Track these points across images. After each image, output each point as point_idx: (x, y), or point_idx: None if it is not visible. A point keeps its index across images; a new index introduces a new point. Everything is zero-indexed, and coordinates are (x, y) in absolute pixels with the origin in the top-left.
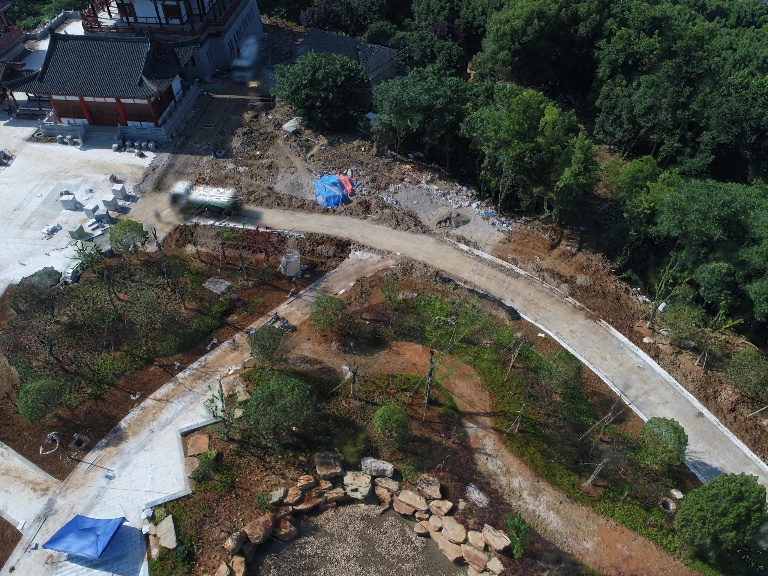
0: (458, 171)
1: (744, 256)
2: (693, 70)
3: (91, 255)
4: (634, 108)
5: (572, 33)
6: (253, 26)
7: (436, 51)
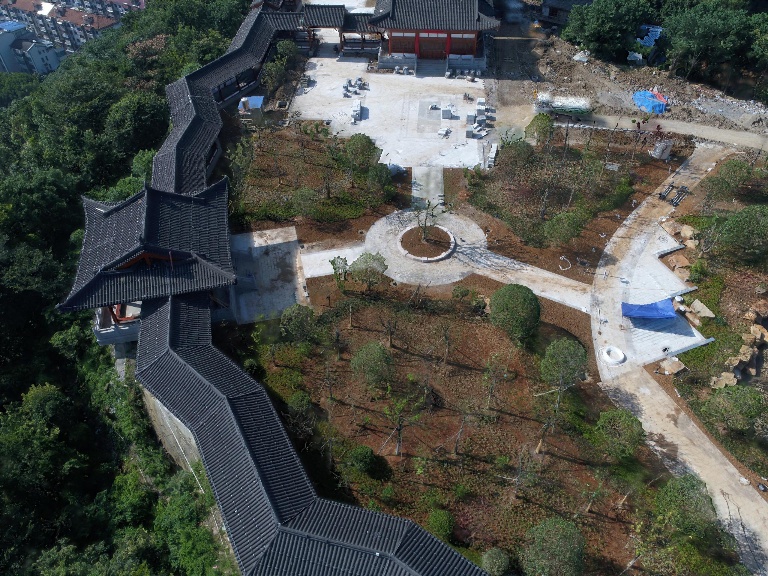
0: (727, 92)
1: None
2: None
3: (512, 142)
4: None
5: None
6: None
7: (662, 0)
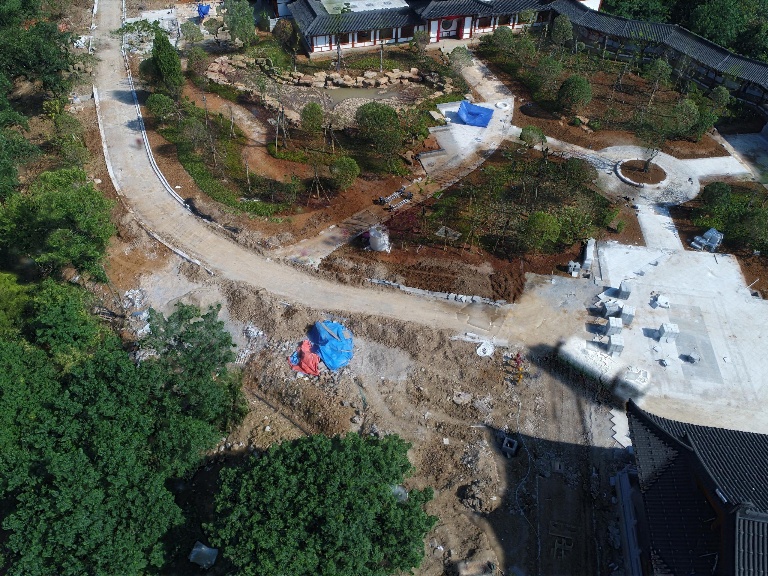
0: None
1: None
2: None
3: None
4: None
5: None
6: None
7: None
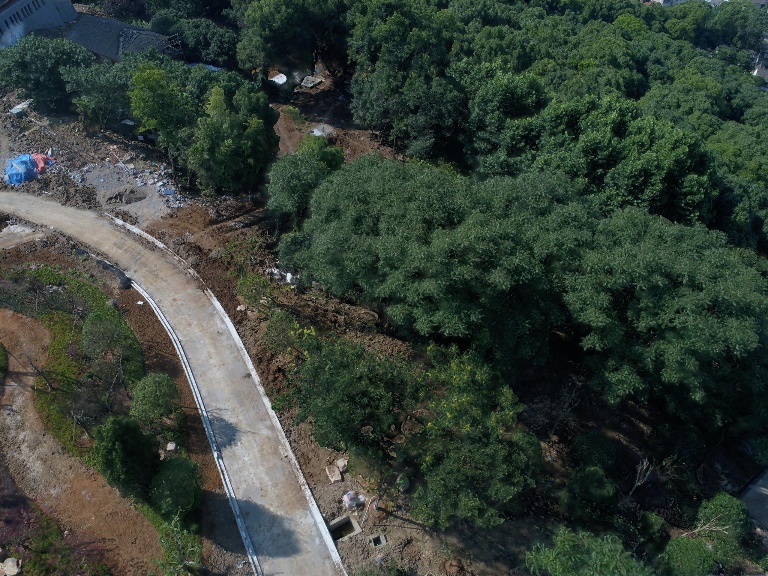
0: None
1: (304, 225)
2: (401, 55)
3: None
4: (370, 93)
5: (342, 21)
6: (43, 13)
7: (208, 38)
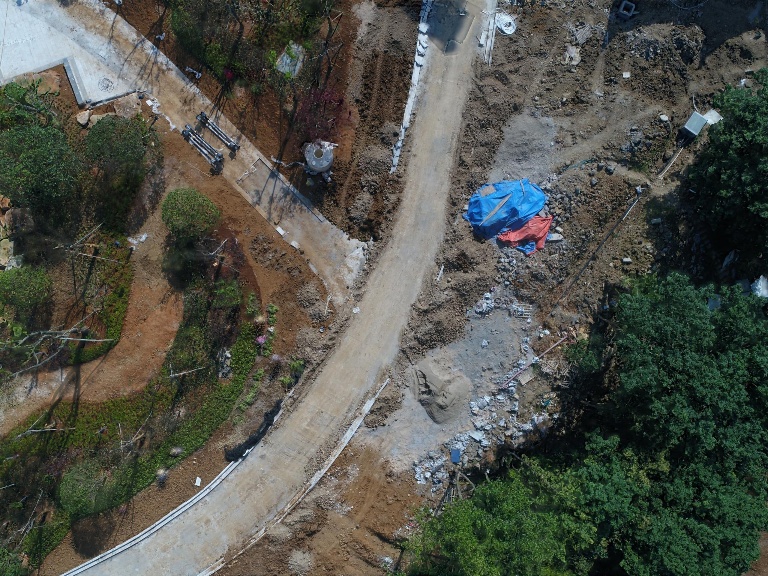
0: (605, 423)
1: None
2: None
3: None
4: None
5: None
6: None
7: None
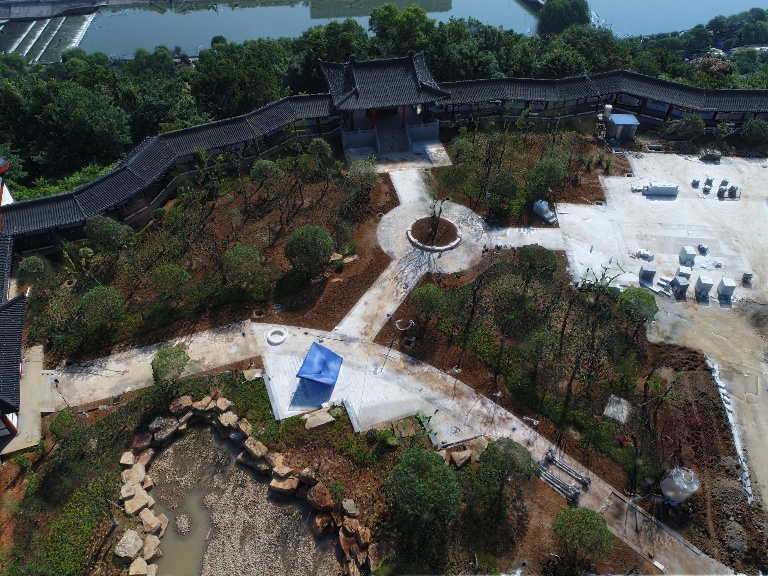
0: None
1: None
2: None
3: (606, 287)
4: None
5: None
6: None
7: None
